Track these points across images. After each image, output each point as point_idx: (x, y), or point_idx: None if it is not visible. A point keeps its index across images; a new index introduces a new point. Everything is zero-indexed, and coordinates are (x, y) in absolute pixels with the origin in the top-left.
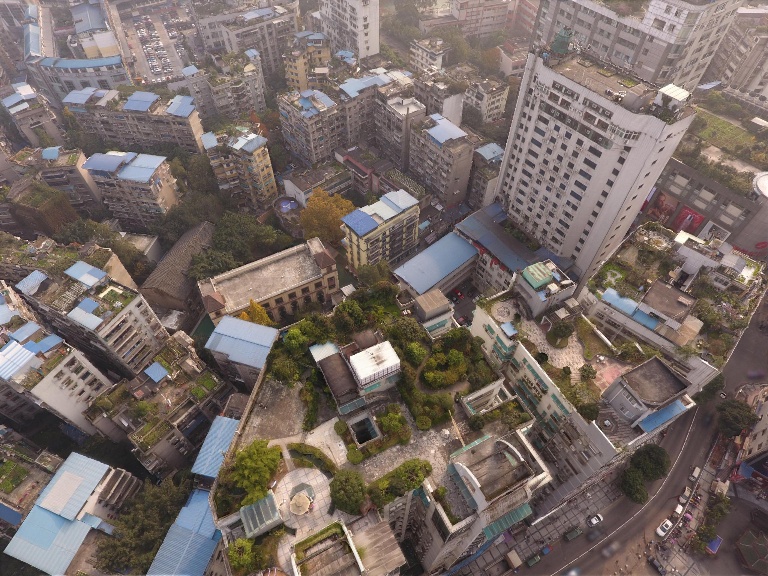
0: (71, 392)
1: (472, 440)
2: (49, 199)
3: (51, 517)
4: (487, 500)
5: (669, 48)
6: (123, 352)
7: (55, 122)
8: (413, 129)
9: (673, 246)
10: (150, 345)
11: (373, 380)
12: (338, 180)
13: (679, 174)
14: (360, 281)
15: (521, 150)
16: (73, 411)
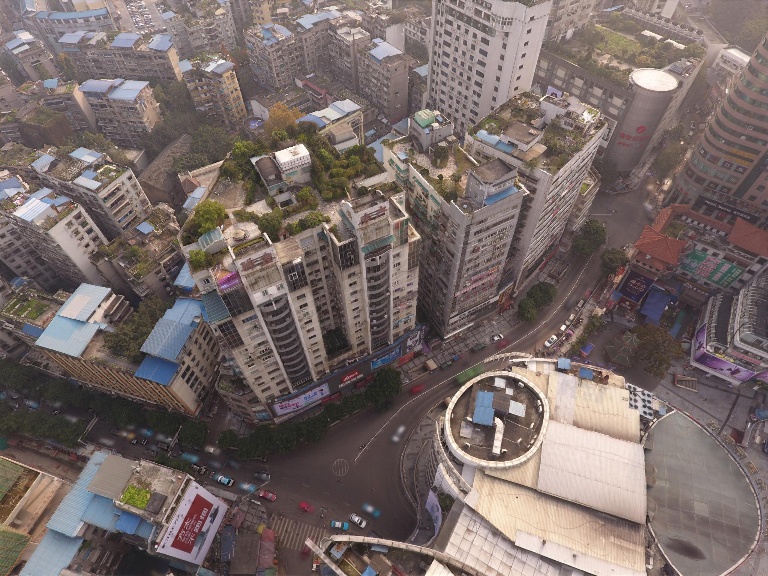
0: (79, 242)
1: None
2: (51, 118)
3: (69, 322)
4: (355, 212)
5: None
6: (119, 217)
7: (52, 61)
8: (359, 53)
9: (539, 106)
10: (140, 217)
11: (291, 168)
12: (298, 101)
13: (577, 77)
14: None
15: (439, 55)
16: (81, 260)
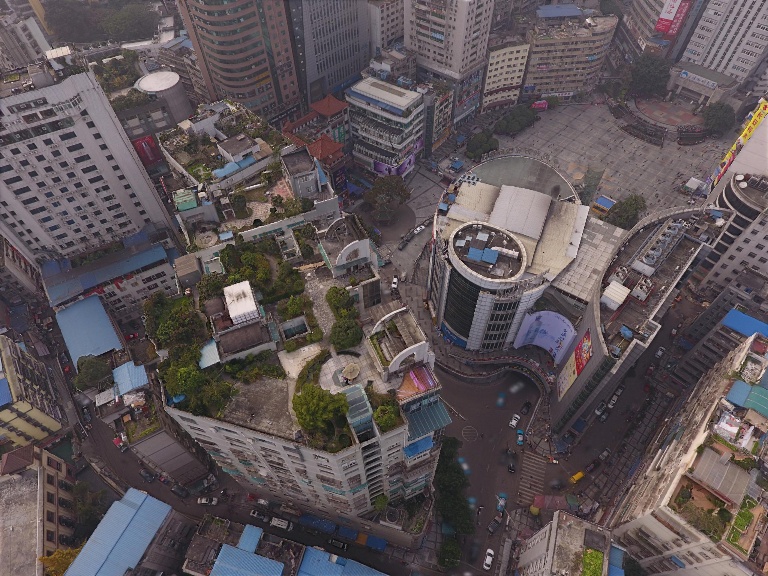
0: None
1: (317, 262)
2: None
3: None
4: (367, 238)
5: None
6: None
7: None
8: None
9: (189, 133)
10: None
11: None
12: None
13: None
14: (96, 385)
15: (4, 203)
16: None
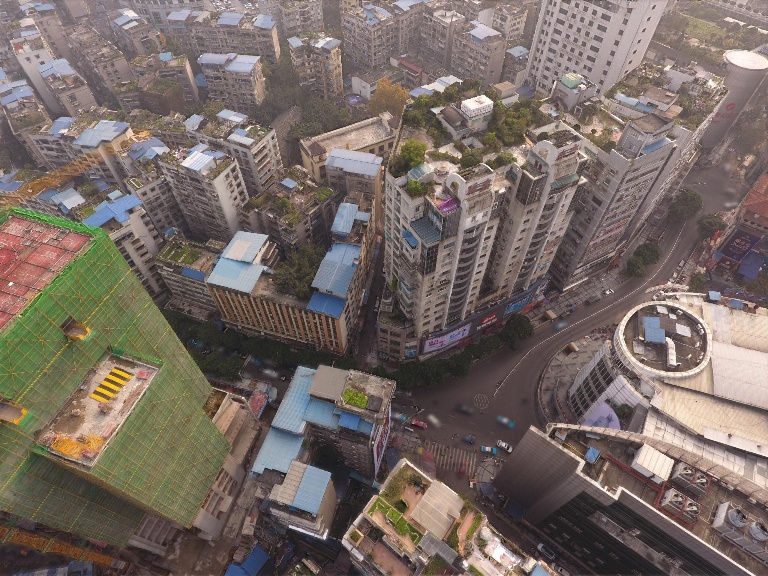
0: (231, 195)
1: None
2: (171, 88)
3: (234, 263)
4: (557, 148)
5: None
6: (261, 174)
7: (158, 38)
8: (456, 34)
9: None
10: (274, 176)
11: (477, 115)
12: (395, 78)
13: (668, 58)
14: None
15: (547, 33)
16: (229, 212)
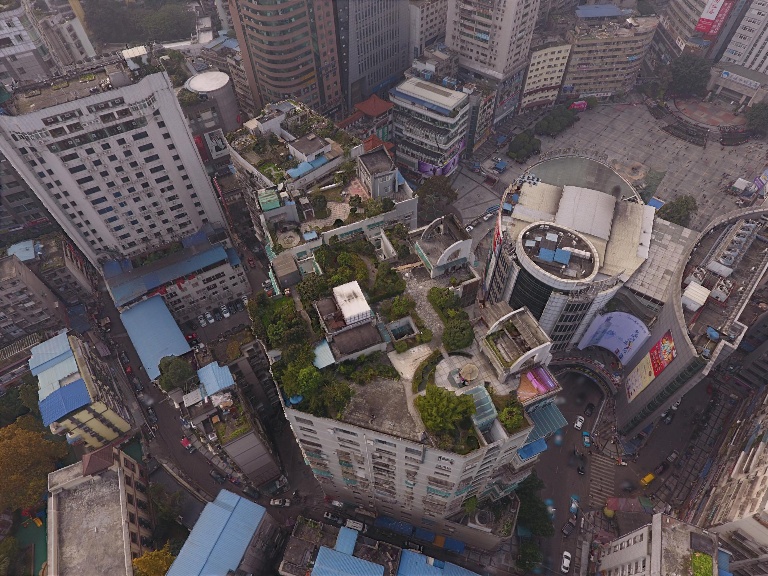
0: None
1: (412, 262)
2: None
3: None
4: None
5: (37, 54)
6: None
7: None
8: None
9: (255, 133)
10: None
11: None
12: None
13: None
14: (182, 386)
15: (74, 203)
16: None
